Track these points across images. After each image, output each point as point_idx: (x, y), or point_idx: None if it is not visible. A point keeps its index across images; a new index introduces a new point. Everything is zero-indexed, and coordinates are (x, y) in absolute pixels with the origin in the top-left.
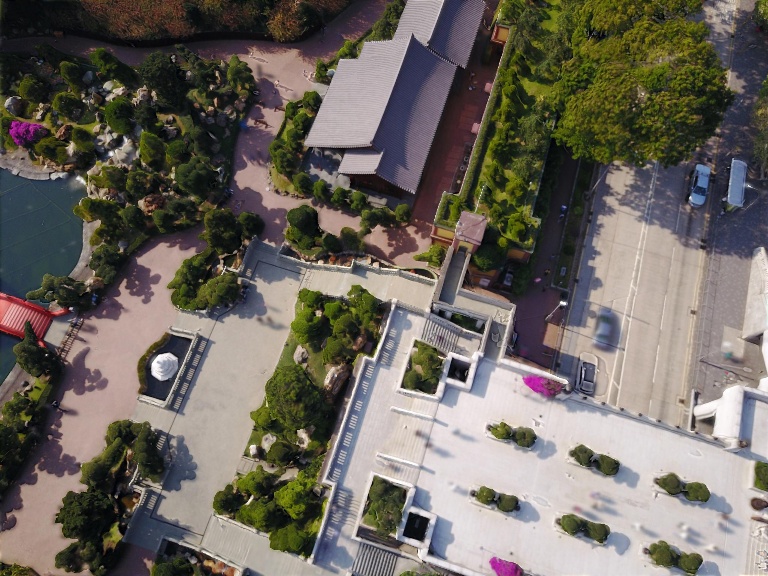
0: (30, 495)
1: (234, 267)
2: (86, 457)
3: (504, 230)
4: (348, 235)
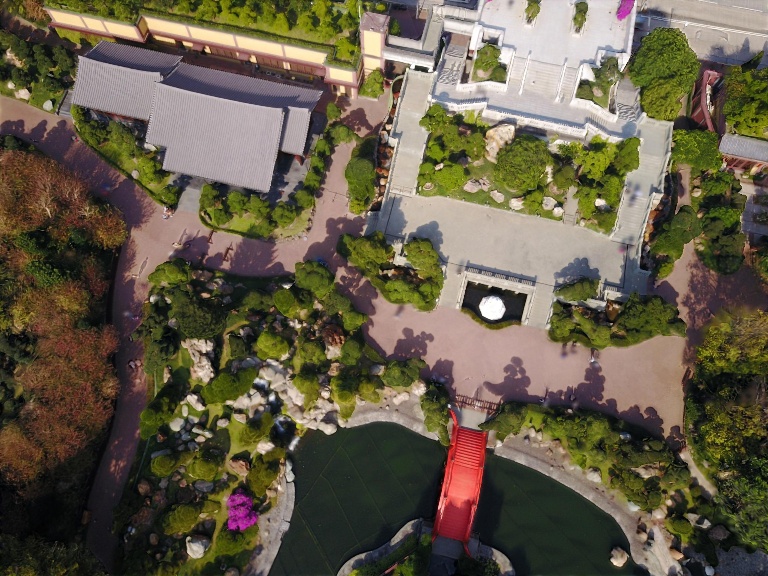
0: (625, 401)
1: (391, 259)
2: (584, 360)
3: (357, 23)
4: (361, 150)
